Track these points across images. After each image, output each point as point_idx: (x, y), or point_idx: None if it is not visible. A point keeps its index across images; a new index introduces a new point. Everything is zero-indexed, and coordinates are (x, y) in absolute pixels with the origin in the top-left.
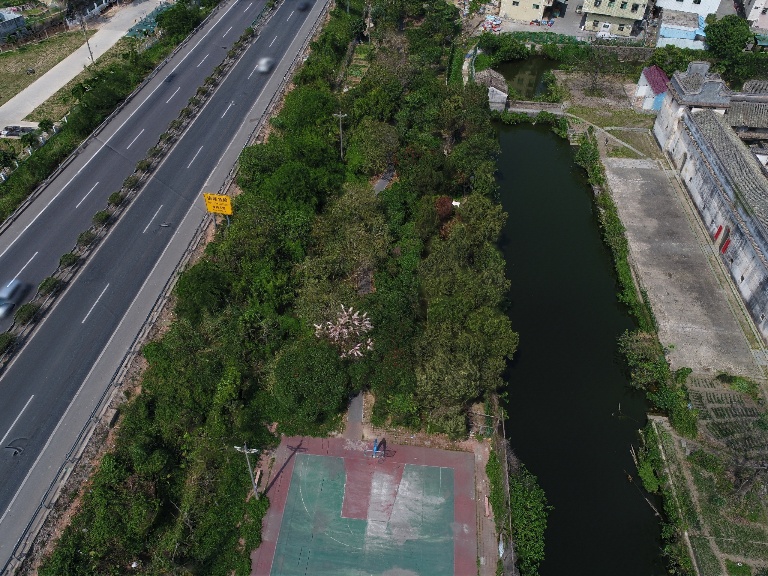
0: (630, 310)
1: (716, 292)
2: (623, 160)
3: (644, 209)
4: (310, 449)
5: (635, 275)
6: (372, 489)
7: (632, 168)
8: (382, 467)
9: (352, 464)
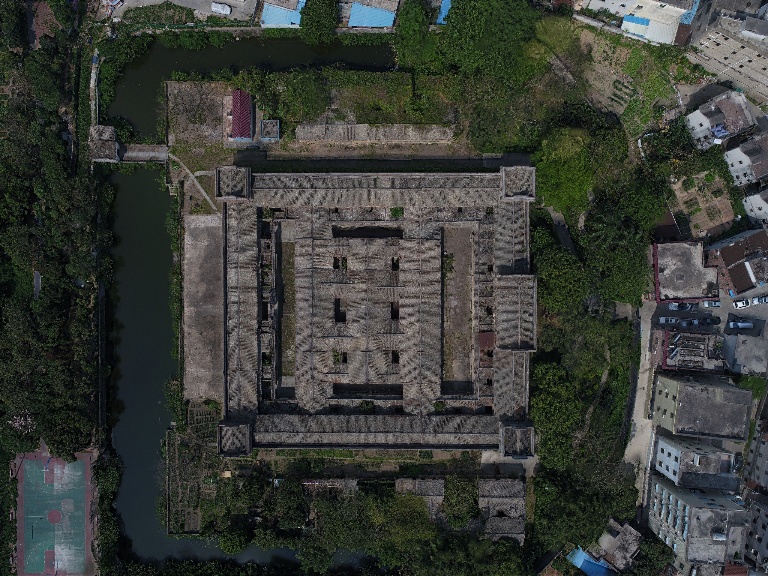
0: (176, 360)
1: (222, 344)
2: (199, 218)
3: (201, 274)
4: (28, 458)
5: (182, 336)
6: (54, 472)
7: (203, 227)
8: (57, 463)
9: (46, 463)
